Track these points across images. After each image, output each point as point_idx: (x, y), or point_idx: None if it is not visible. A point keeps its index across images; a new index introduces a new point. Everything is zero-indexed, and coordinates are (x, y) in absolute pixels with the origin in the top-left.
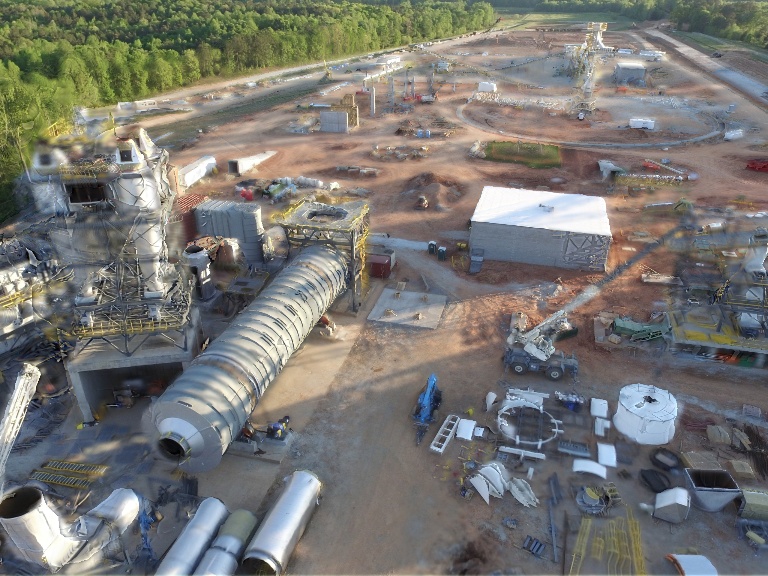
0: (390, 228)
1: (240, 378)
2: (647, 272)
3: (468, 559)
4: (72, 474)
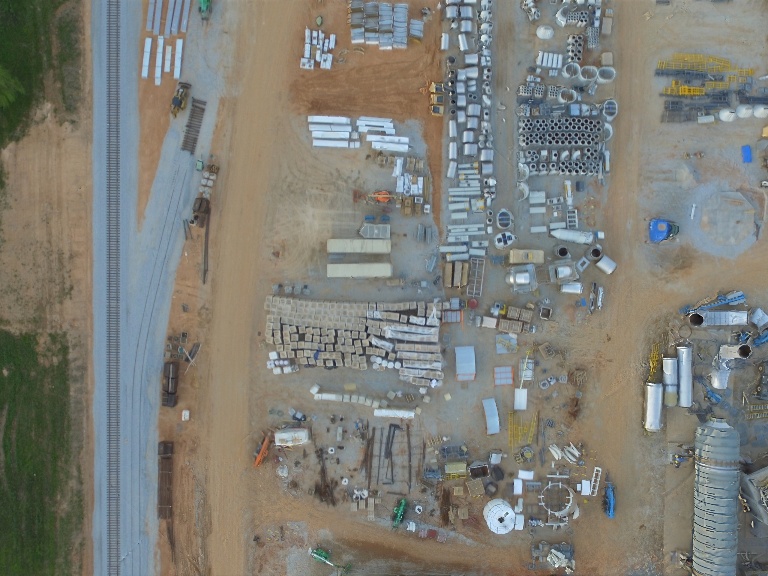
0: None
1: (710, 462)
2: None
3: (576, 411)
4: (759, 411)
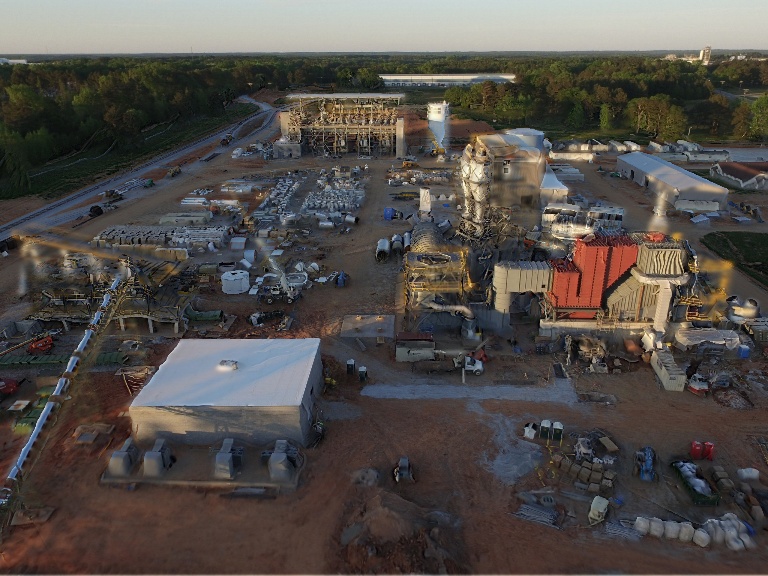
0: (430, 416)
1: None
2: (138, 384)
3: None
4: None
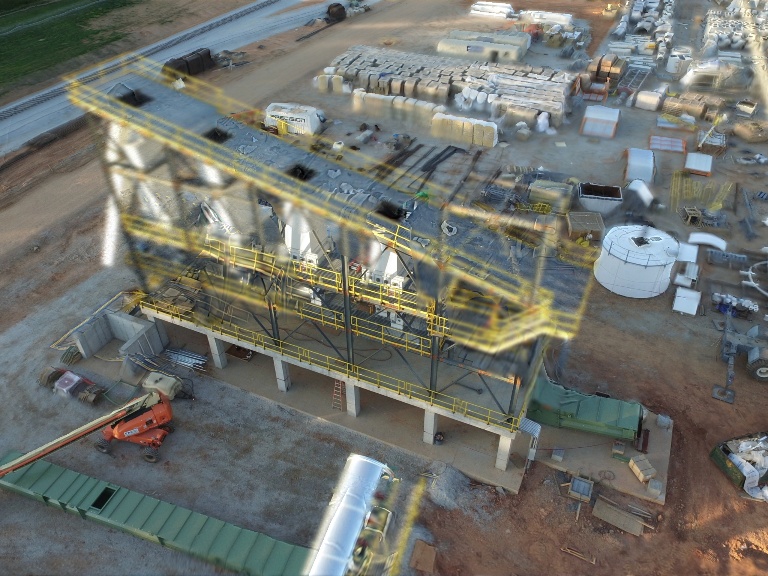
0: None
1: None
2: None
3: None
4: None
